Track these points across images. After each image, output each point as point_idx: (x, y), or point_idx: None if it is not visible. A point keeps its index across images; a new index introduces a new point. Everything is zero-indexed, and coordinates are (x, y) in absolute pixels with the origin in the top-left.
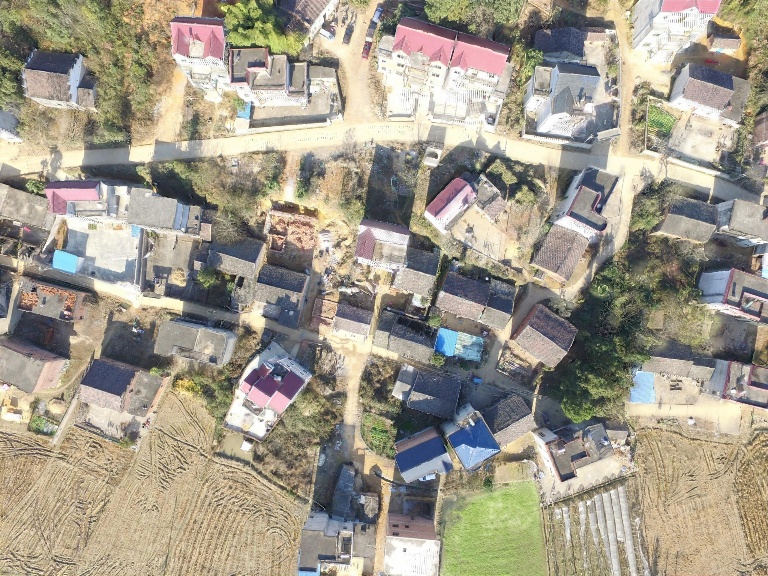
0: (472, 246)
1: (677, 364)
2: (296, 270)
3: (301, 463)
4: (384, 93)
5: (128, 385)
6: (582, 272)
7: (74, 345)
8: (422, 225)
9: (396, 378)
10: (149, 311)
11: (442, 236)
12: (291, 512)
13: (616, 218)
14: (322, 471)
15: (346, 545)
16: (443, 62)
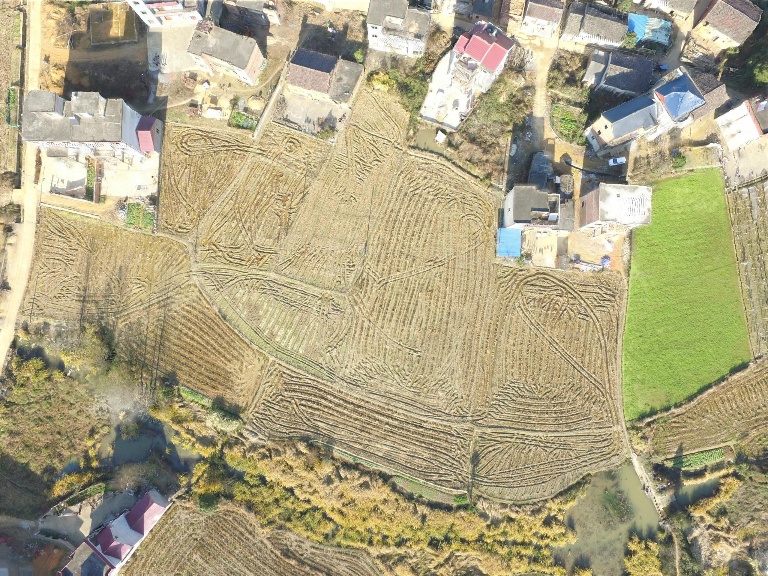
0: None
1: None
2: None
3: (495, 150)
4: None
5: (335, 64)
6: None
7: (270, 46)
8: None
9: (585, 67)
10: (342, 14)
11: None
12: (485, 200)
13: None
14: (513, 161)
15: (552, 208)
16: None
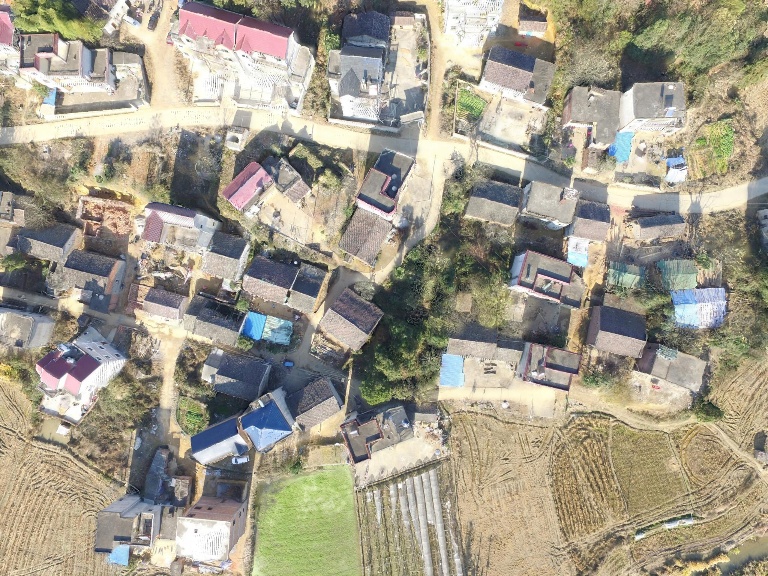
0: (279, 230)
1: (481, 347)
2: (112, 255)
3: (116, 447)
4: (190, 78)
5: None
6: (392, 256)
7: None
8: (229, 209)
9: None
10: None
11: (249, 220)
12: (107, 495)
13: (427, 202)
14: (138, 455)
15: (148, 527)
16: (227, 45)
